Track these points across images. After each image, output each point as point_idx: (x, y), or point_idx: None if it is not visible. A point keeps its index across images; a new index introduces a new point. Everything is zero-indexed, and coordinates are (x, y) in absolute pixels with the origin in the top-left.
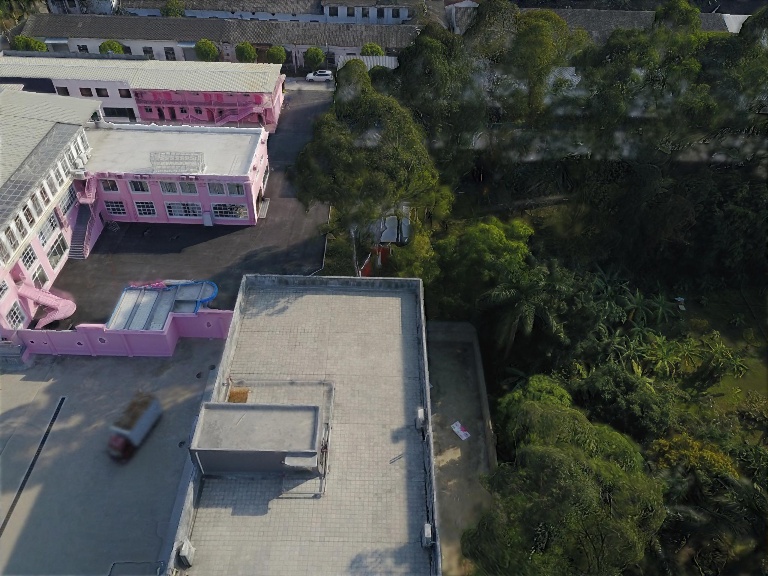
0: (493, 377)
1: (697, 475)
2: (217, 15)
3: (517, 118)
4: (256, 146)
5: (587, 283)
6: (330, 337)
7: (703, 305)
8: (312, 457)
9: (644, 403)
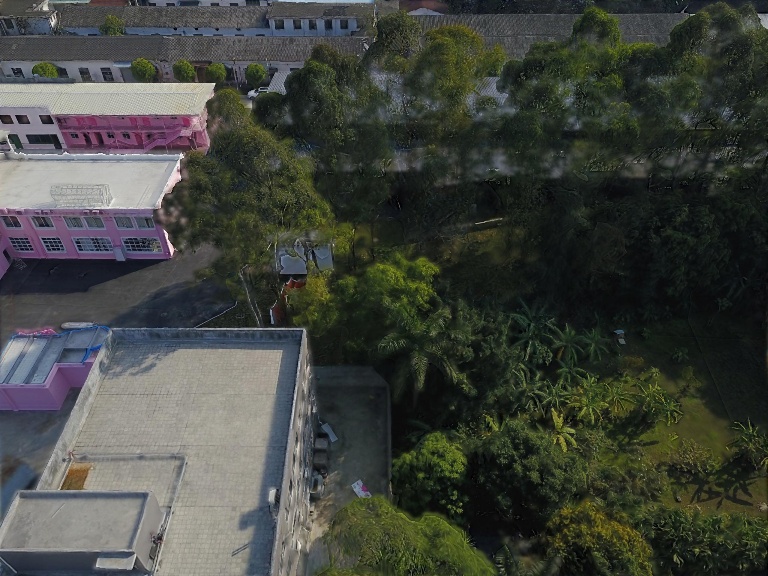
0: (403, 428)
1: (594, 557)
2: (159, 32)
3: (427, 143)
4: (171, 174)
5: (498, 326)
6: (195, 400)
7: (645, 338)
8: (128, 557)
9: (545, 468)
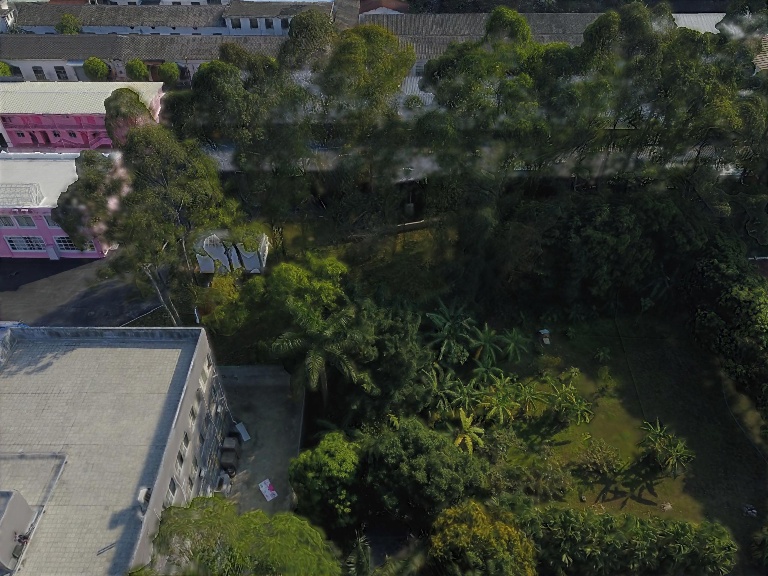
0: (316, 427)
1: (468, 557)
2: (116, 31)
3: (343, 142)
4: None
5: (404, 325)
6: (85, 399)
7: (569, 338)
8: None
9: (432, 468)
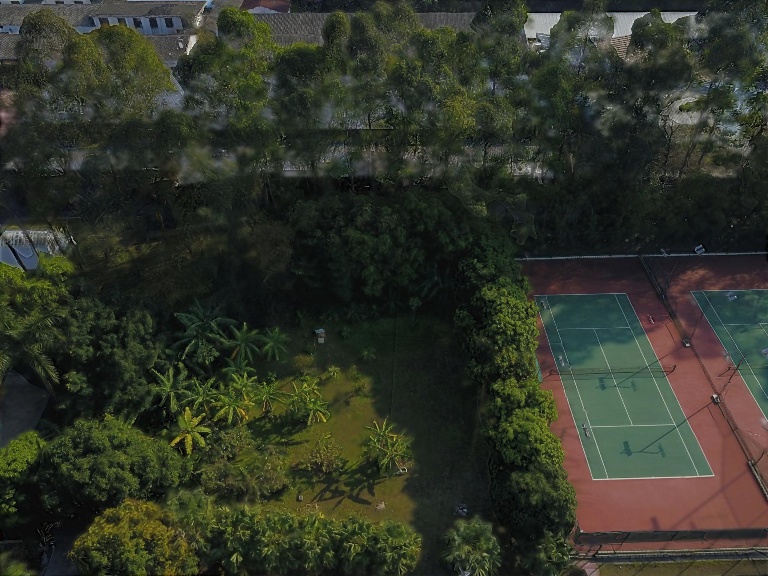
0: None
1: (93, 556)
2: None
3: (92, 142)
4: None
5: (125, 325)
6: None
7: (343, 337)
8: None
9: (96, 467)
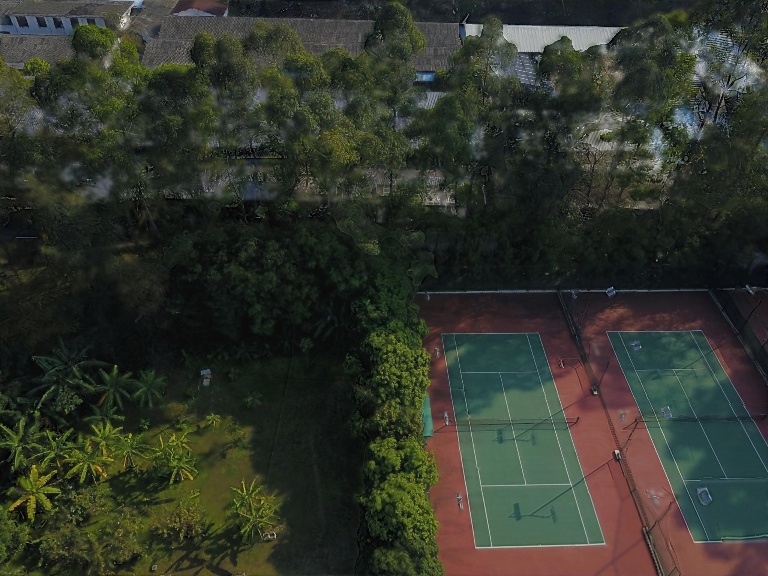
0: None
1: None
2: None
3: None
4: None
5: None
6: None
7: (230, 379)
8: None
9: None
